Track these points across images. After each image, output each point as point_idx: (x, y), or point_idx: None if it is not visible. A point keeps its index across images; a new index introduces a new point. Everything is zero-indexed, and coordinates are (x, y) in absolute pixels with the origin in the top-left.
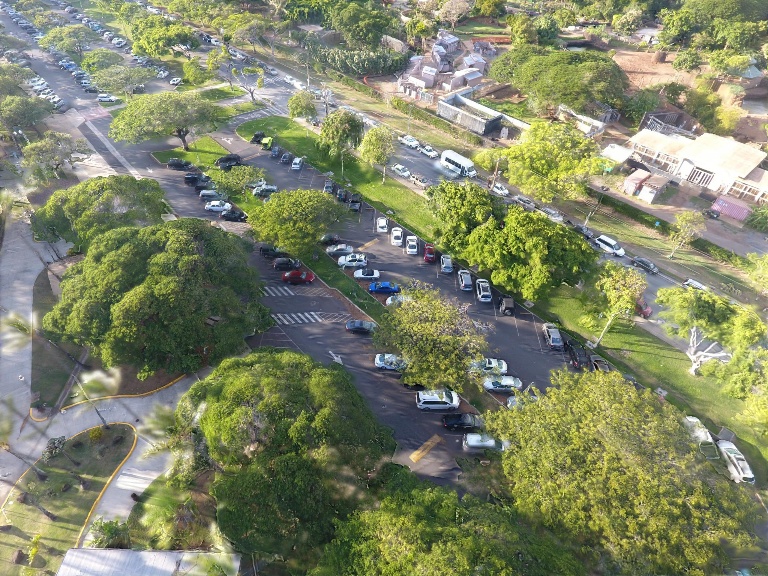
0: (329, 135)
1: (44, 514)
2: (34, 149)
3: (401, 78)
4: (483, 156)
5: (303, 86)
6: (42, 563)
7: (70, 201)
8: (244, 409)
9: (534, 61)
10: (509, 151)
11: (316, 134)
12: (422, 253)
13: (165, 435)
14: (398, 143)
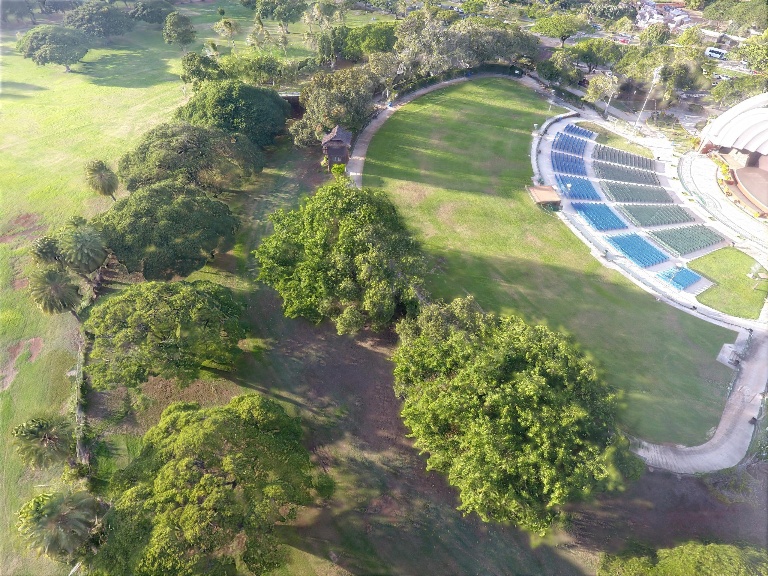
0: (654, 35)
1: (668, 128)
2: None
3: (643, 20)
4: (752, 39)
5: None
6: (683, 135)
7: (595, 45)
8: (760, 78)
9: (741, 5)
10: (767, 35)
11: None
12: None
13: (685, 117)
14: None
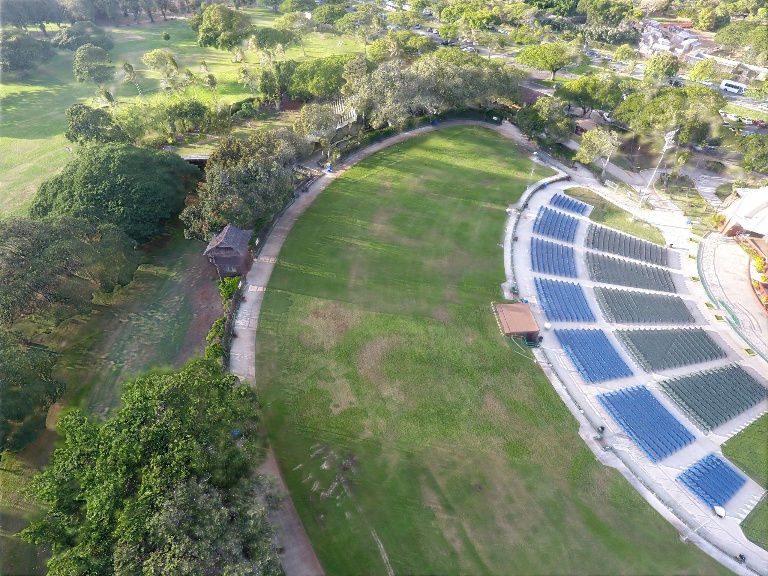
0: (660, 67)
1: (682, 196)
2: (508, 69)
3: (646, 45)
4: None
5: (580, 50)
6: None
7: (590, 84)
8: None
9: (760, 29)
10: None
11: (621, 74)
12: (754, 124)
13: (702, 178)
14: (679, 79)
